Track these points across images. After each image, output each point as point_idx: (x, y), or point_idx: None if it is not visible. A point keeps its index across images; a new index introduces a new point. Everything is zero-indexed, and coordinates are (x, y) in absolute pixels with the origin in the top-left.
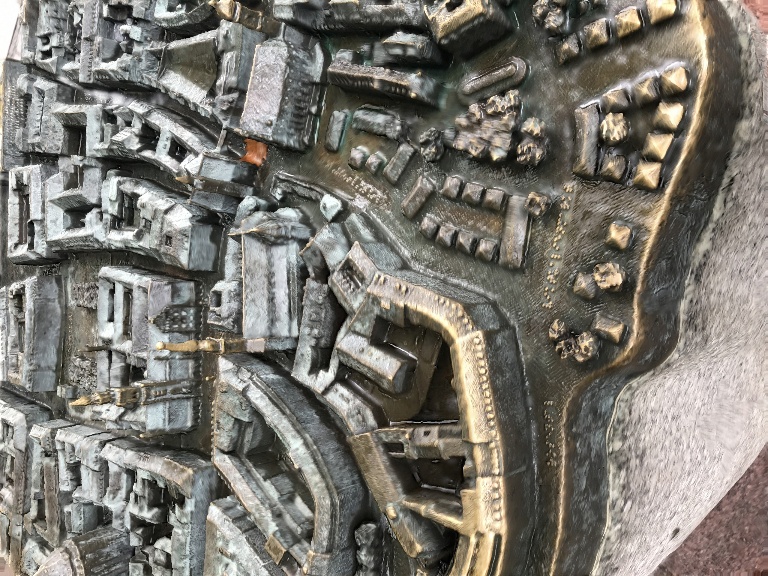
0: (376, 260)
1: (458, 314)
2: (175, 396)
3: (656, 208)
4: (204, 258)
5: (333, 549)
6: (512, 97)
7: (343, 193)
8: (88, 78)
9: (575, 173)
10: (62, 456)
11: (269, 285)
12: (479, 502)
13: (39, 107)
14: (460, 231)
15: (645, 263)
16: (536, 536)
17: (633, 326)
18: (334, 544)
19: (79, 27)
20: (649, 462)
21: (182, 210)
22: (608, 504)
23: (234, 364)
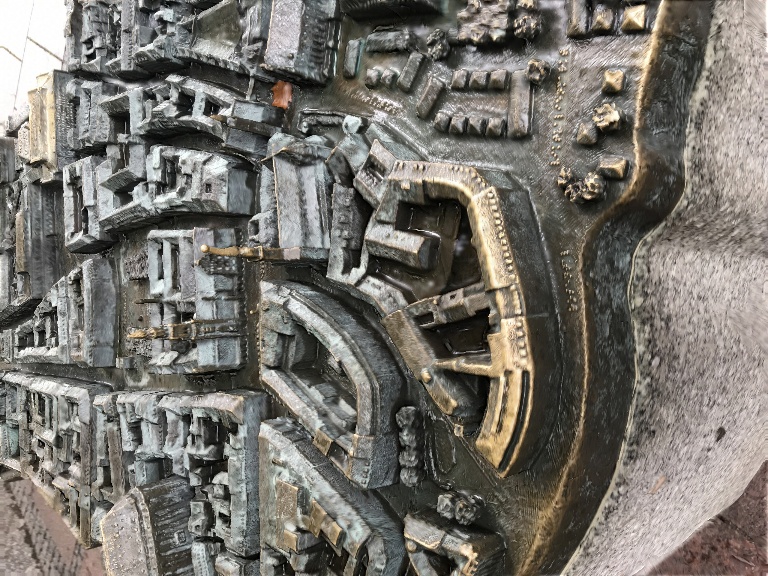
0: (395, 153)
1: (471, 176)
2: (223, 334)
3: (645, 48)
4: (241, 202)
5: (376, 432)
6: None
7: (363, 113)
8: (129, 66)
9: (569, 36)
10: (123, 418)
11: (301, 202)
12: (505, 341)
13: (87, 106)
14: (470, 117)
15: (640, 101)
16: (565, 381)
17: (635, 161)
18: (377, 427)
19: (118, 24)
20: (676, 329)
21: (219, 159)
22: (635, 358)
23: (274, 284)
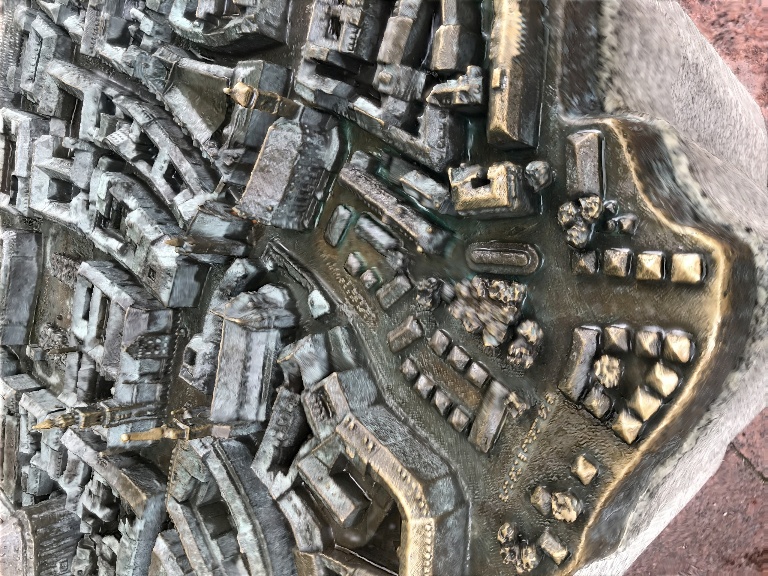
0: (351, 396)
1: (416, 495)
2: (139, 418)
3: (626, 459)
4: (186, 295)
5: None
6: (517, 293)
7: (333, 292)
8: (90, 51)
9: (560, 389)
10: (24, 421)
11: (244, 369)
12: None
13: (35, 50)
14: (438, 389)
15: (603, 503)
16: None
17: (576, 554)
18: None
19: None
20: None
21: (170, 245)
22: None
23: None
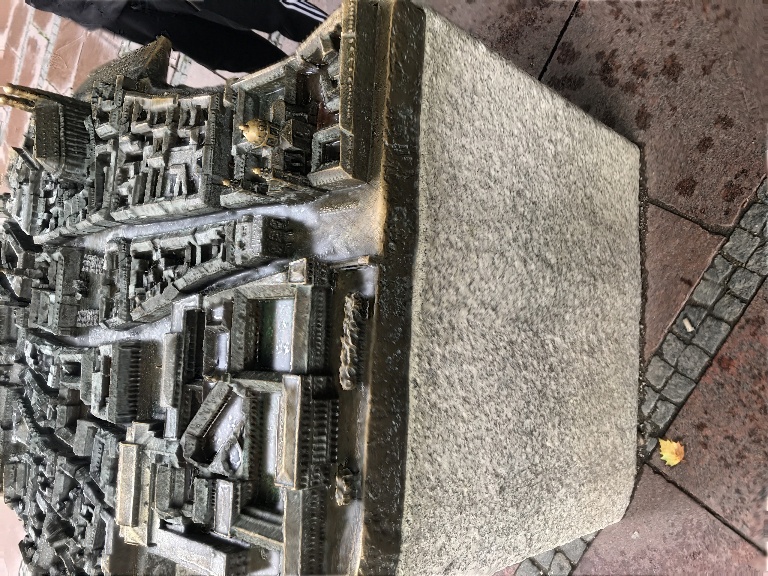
0: None
1: None
2: None
3: None
4: None
5: None
6: None
7: None
8: None
9: None
10: None
11: None
12: None
13: None
14: None
15: None
16: None
17: None
18: None
19: None
20: None
21: None
22: None
23: None
